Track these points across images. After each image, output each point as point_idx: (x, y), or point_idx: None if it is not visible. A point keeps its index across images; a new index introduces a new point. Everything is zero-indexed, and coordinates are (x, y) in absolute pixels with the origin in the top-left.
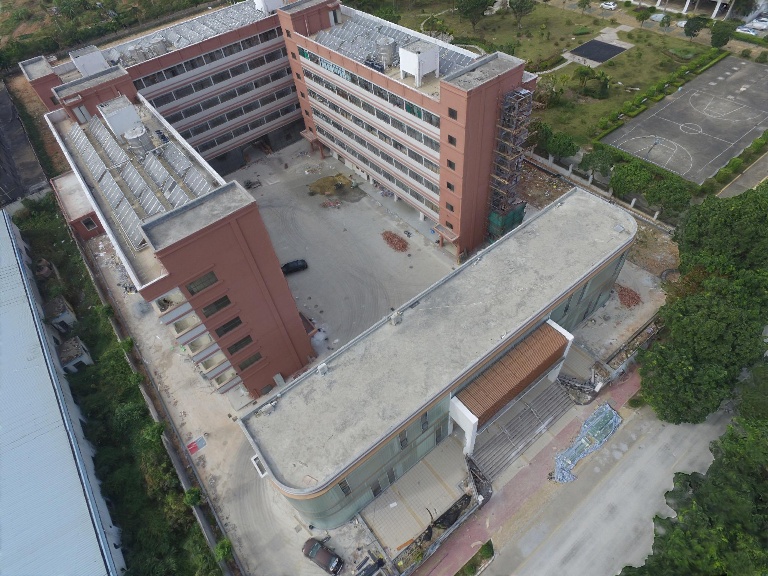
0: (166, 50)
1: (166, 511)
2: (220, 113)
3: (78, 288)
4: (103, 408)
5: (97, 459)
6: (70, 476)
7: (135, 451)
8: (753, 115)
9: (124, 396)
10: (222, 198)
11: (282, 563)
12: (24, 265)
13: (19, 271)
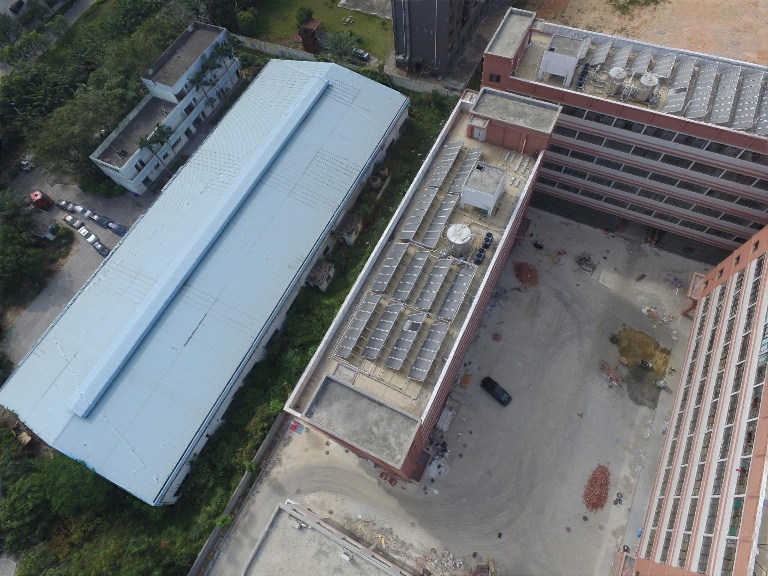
0: (649, 96)
1: (239, 451)
2: (636, 184)
3: (382, 213)
4: (292, 335)
5: (256, 368)
6: (225, 378)
7: (270, 390)
8: None
9: (307, 343)
10: (396, 420)
11: (243, 558)
12: (370, 166)
13: (357, 177)
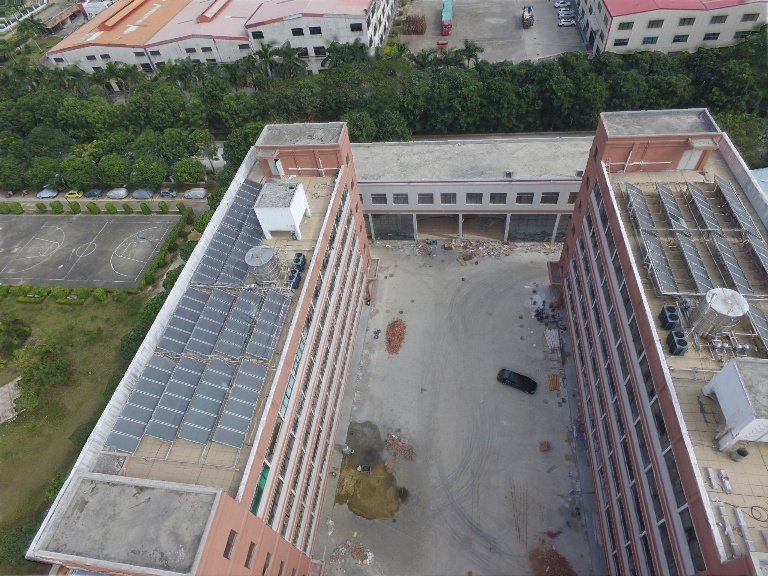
0: None
1: None
2: None
3: None
4: None
5: None
6: None
7: None
8: (51, 229)
9: None
10: None
11: None
12: None
13: None
